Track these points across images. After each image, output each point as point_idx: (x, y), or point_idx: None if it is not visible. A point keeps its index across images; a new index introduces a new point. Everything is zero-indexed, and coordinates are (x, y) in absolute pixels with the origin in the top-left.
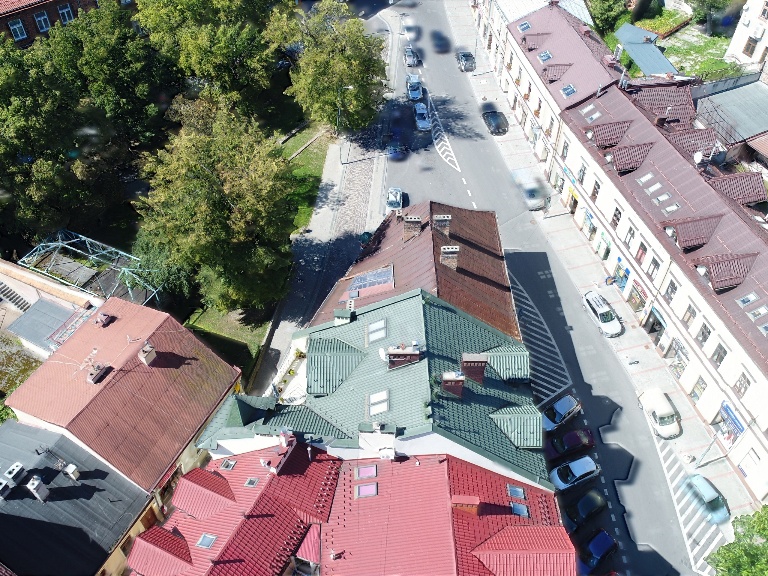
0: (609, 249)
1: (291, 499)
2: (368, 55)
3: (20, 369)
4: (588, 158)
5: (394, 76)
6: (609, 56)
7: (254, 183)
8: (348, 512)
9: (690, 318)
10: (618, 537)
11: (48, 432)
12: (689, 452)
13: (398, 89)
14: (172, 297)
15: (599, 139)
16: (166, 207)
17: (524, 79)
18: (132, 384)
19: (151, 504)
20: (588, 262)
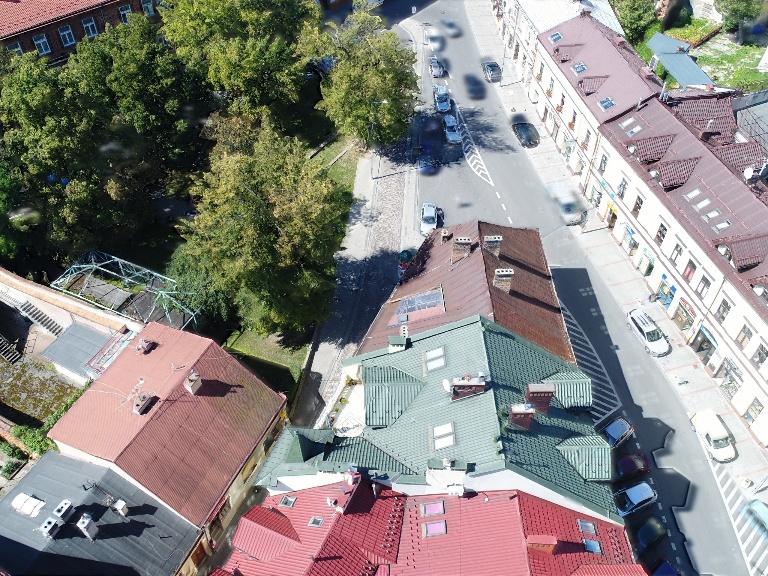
0: (652, 265)
1: (358, 539)
2: (400, 68)
3: (55, 396)
4: (630, 173)
5: (420, 87)
6: (646, 68)
7: (304, 206)
8: (417, 552)
9: (745, 338)
10: (680, 567)
11: (93, 465)
12: (746, 476)
13: (425, 101)
14: (209, 320)
15: (643, 154)
16: (209, 230)
17: (556, 91)
18: (178, 414)
19: (201, 539)
20: (629, 278)
